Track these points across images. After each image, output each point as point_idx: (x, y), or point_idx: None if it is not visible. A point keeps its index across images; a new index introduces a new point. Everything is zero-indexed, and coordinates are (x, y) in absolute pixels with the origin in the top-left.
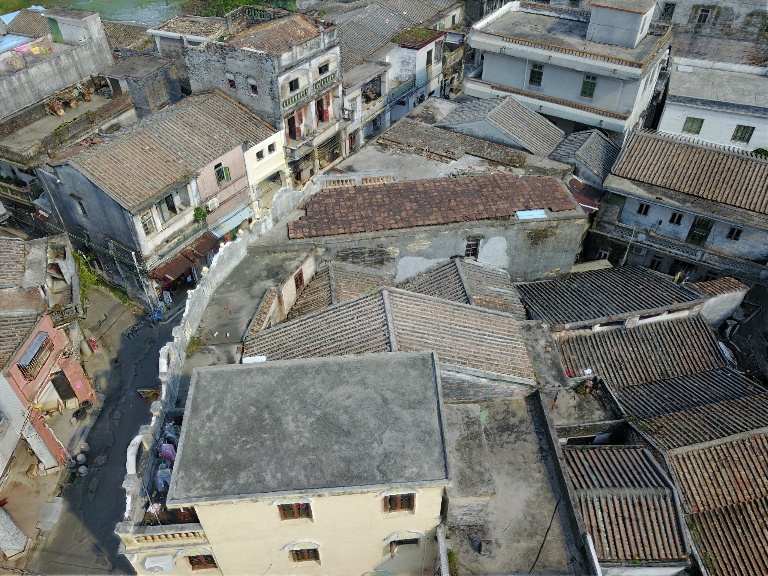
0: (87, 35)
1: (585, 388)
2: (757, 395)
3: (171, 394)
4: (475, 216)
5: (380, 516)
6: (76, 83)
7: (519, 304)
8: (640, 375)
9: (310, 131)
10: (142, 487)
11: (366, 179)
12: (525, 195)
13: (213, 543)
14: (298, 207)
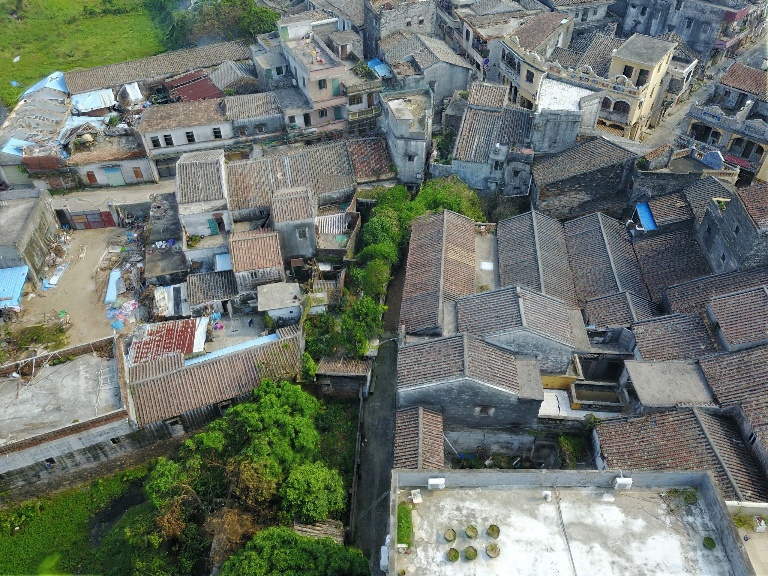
0: (308, 29)
1: None
2: None
3: None
4: None
5: None
6: None
7: None
8: None
9: None
10: None
11: None
12: None
13: (647, 89)
14: None
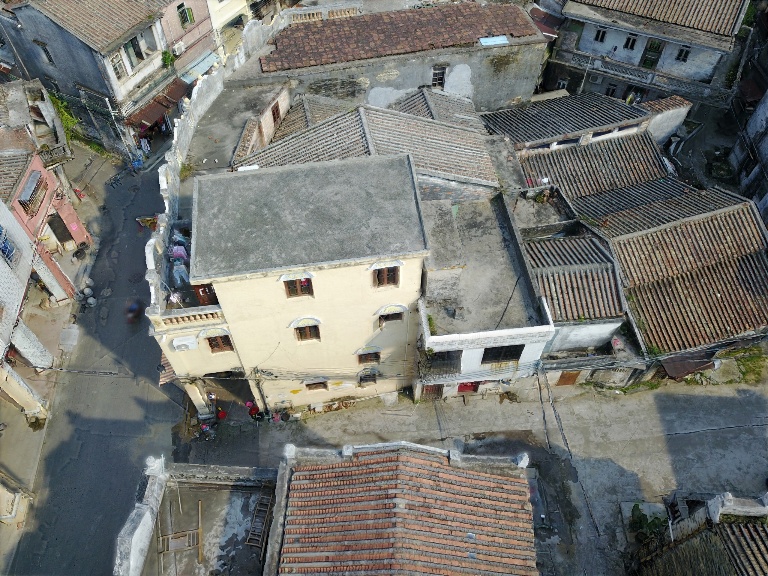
0: None
1: (543, 197)
2: (691, 193)
3: (173, 210)
4: (441, 44)
5: (370, 290)
6: None
7: (483, 129)
8: (592, 186)
9: None
10: (161, 282)
11: (332, 12)
12: (488, 22)
13: (230, 322)
14: (268, 42)
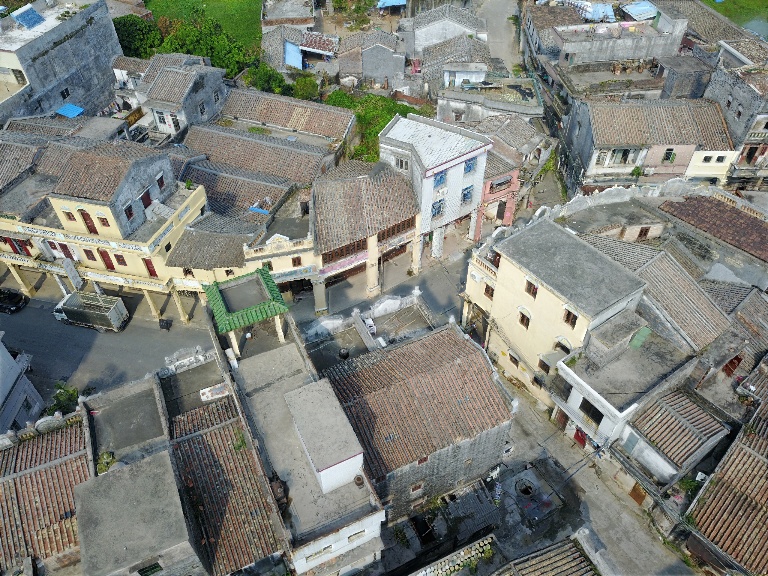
0: (671, 31)
1: (746, 399)
2: None
3: None
4: None
5: (560, 320)
6: (641, 58)
7: None
8: None
9: (763, 163)
10: (492, 246)
11: (745, 207)
12: None
13: (497, 282)
14: (684, 196)
